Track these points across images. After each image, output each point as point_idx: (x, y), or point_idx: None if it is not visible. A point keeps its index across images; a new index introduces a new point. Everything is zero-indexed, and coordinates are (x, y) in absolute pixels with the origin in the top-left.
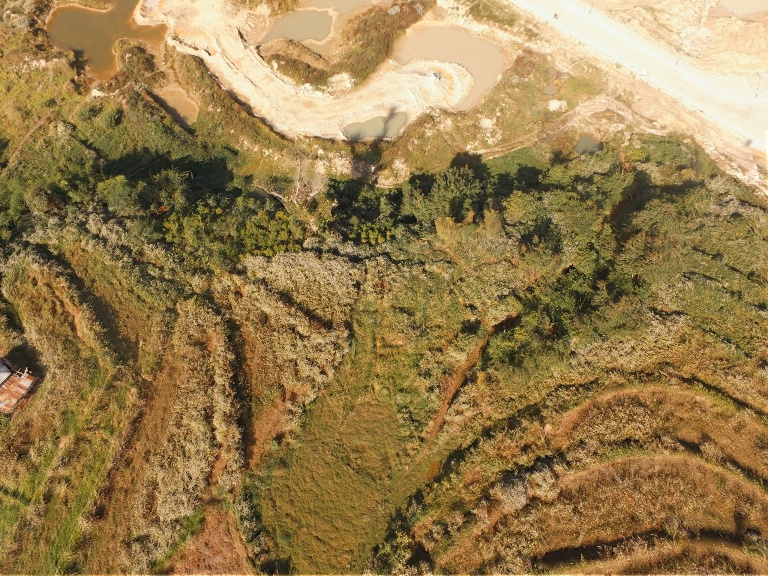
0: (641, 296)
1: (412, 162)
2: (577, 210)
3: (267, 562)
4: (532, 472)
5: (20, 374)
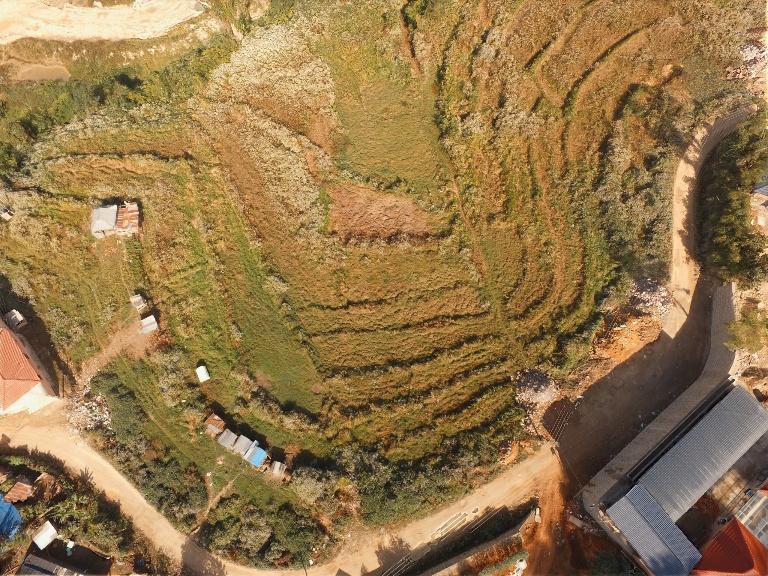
0: None
1: None
2: None
3: None
4: (485, 40)
5: (123, 207)
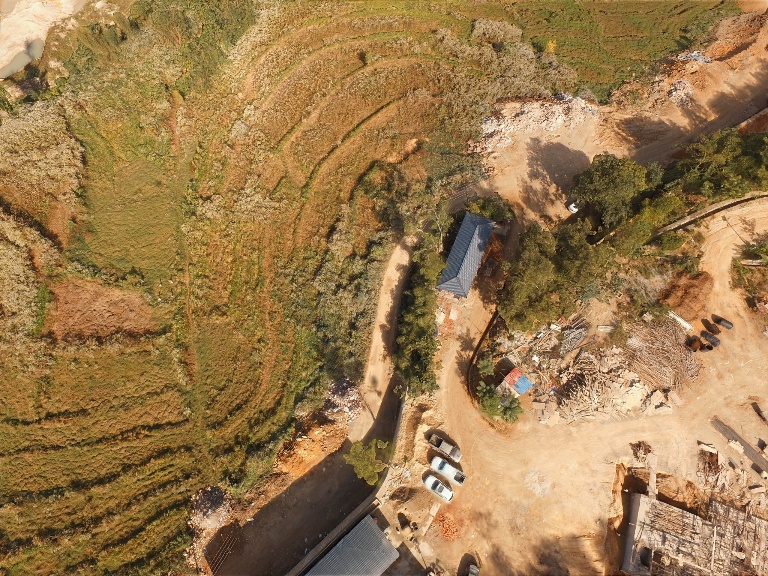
0: None
1: (65, 57)
2: None
3: None
4: None
5: None
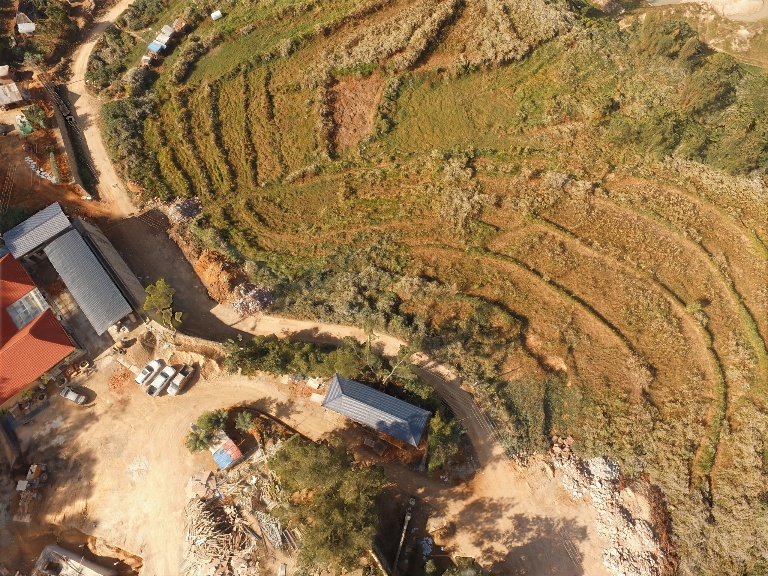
0: (762, 160)
1: None
2: (764, 91)
3: (385, 116)
4: None
5: None
